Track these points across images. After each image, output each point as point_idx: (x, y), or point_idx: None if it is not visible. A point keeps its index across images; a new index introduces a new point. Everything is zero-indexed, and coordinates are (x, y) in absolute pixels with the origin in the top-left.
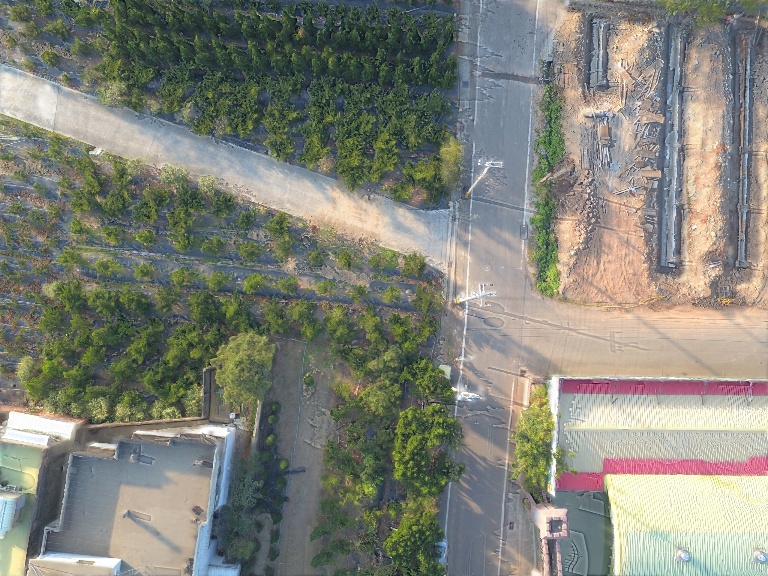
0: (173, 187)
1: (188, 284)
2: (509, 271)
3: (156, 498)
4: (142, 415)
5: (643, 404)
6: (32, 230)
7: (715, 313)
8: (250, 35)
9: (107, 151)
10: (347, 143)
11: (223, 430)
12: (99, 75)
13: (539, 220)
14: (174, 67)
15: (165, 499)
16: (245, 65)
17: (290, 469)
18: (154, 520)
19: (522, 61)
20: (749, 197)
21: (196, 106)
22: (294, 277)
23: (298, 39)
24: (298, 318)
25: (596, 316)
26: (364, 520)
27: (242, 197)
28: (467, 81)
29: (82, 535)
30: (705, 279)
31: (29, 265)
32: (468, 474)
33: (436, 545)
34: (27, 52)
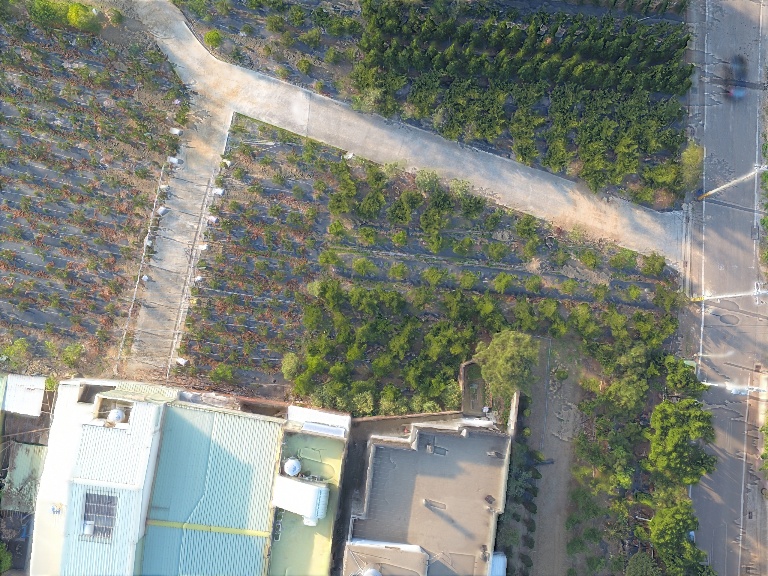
0: (422, 190)
1: (438, 283)
2: (742, 270)
3: (450, 487)
4: (406, 409)
5: None
6: (288, 232)
7: None
8: (497, 44)
9: (358, 155)
10: (590, 147)
11: (489, 423)
12: (348, 82)
13: None
14: (425, 74)
15: (459, 488)
16: (492, 72)
17: None
18: (449, 508)
19: (748, 68)
20: None
21: (446, 112)
22: (538, 276)
23: (543, 47)
24: (550, 316)
25: None
26: (614, 510)
27: None
28: (696, 87)
29: None
30: None
31: (287, 265)
32: None
33: None
34: (280, 60)
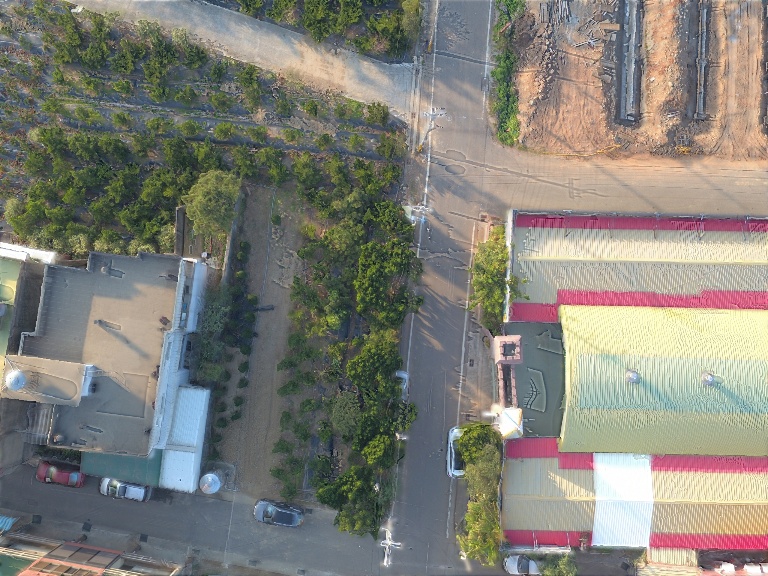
0: (150, 42)
1: (163, 133)
2: (470, 121)
3: (126, 309)
4: (118, 250)
5: (596, 237)
6: (18, 83)
7: (672, 161)
8: None
9: (88, 9)
10: None
11: (193, 260)
12: None
13: (500, 72)
14: None
15: (134, 310)
16: None
17: (259, 307)
18: (124, 329)
19: None
20: (708, 52)
21: None
22: (264, 127)
23: None
24: (266, 161)
25: (555, 164)
26: (329, 353)
27: (215, 51)
28: None
29: (56, 340)
30: (662, 127)
31: (15, 115)
32: (429, 313)
33: (397, 376)
34: None
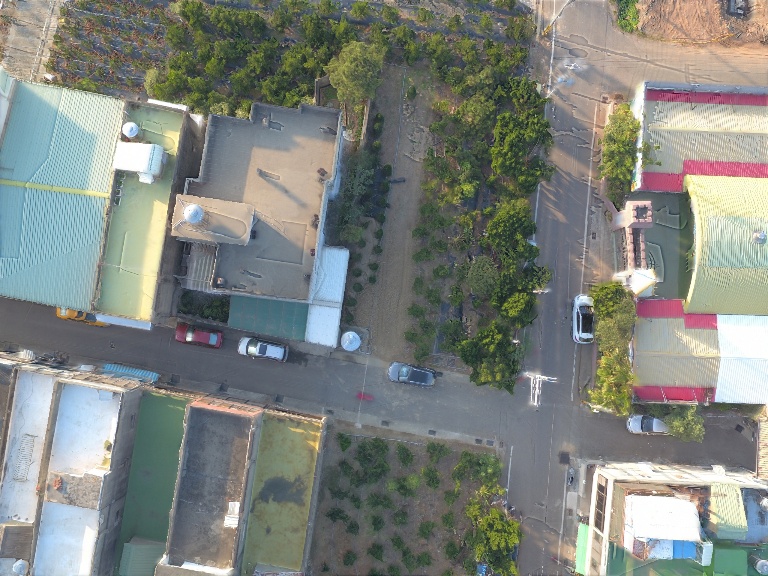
0: None
1: (298, 11)
2: (592, 8)
3: (284, 160)
4: None
5: (720, 111)
6: None
7: None
8: None
9: None
10: None
11: None
12: None
13: None
14: None
15: (292, 161)
16: None
17: (391, 179)
18: (283, 179)
19: None
20: None
21: None
22: (395, 8)
23: None
24: (402, 36)
25: (672, 50)
26: (460, 222)
27: None
28: None
29: (219, 187)
30: None
31: None
32: (555, 187)
33: None
34: None
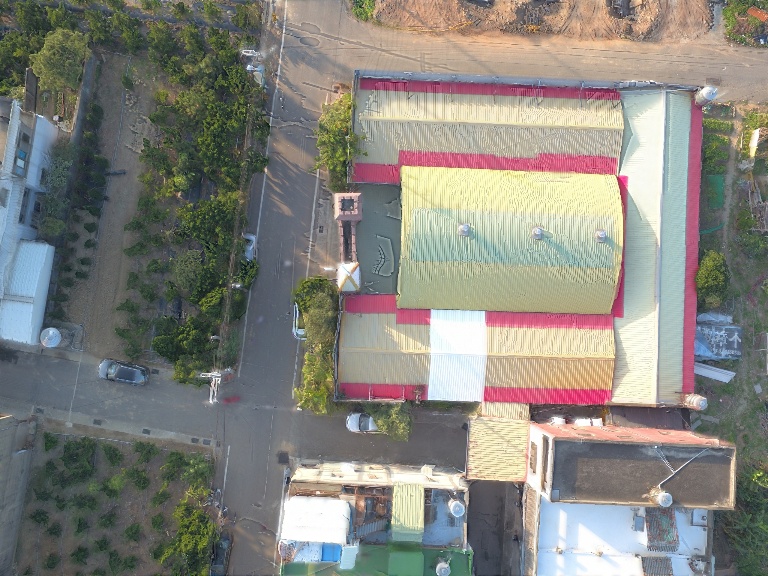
0: None
1: None
2: None
3: None
4: None
5: (437, 100)
6: None
7: (522, 39)
8: None
9: None
10: None
11: None
12: None
13: None
14: None
15: None
16: None
17: (111, 171)
18: None
19: None
20: None
21: None
22: None
23: None
24: (118, 24)
25: (408, 38)
26: (178, 215)
27: None
28: None
29: None
30: (512, 5)
31: None
32: (280, 179)
33: (243, 237)
34: None
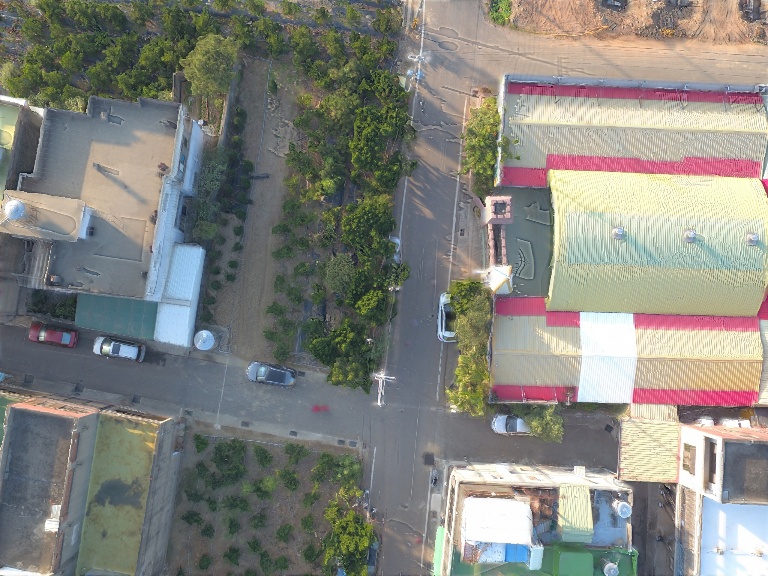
0: None
1: (161, 4)
2: (463, 0)
3: (124, 155)
4: None
5: (584, 105)
6: None
7: (657, 43)
8: None
9: None
10: None
11: None
12: None
13: None
14: None
15: (133, 156)
16: None
17: (254, 174)
18: (122, 175)
19: None
20: None
21: None
22: (261, 1)
23: None
24: (263, 29)
25: (545, 43)
26: (323, 219)
27: None
28: None
29: (54, 182)
30: (647, 10)
31: None
32: (422, 183)
33: (390, 240)
34: None
